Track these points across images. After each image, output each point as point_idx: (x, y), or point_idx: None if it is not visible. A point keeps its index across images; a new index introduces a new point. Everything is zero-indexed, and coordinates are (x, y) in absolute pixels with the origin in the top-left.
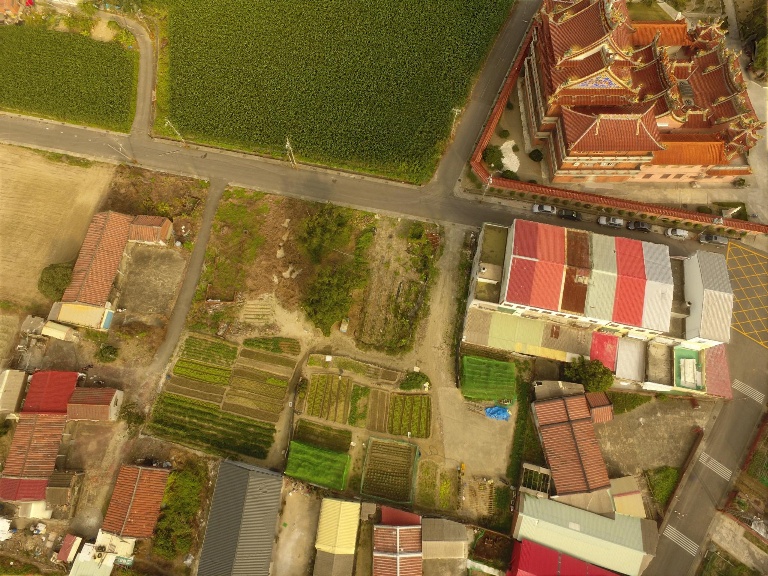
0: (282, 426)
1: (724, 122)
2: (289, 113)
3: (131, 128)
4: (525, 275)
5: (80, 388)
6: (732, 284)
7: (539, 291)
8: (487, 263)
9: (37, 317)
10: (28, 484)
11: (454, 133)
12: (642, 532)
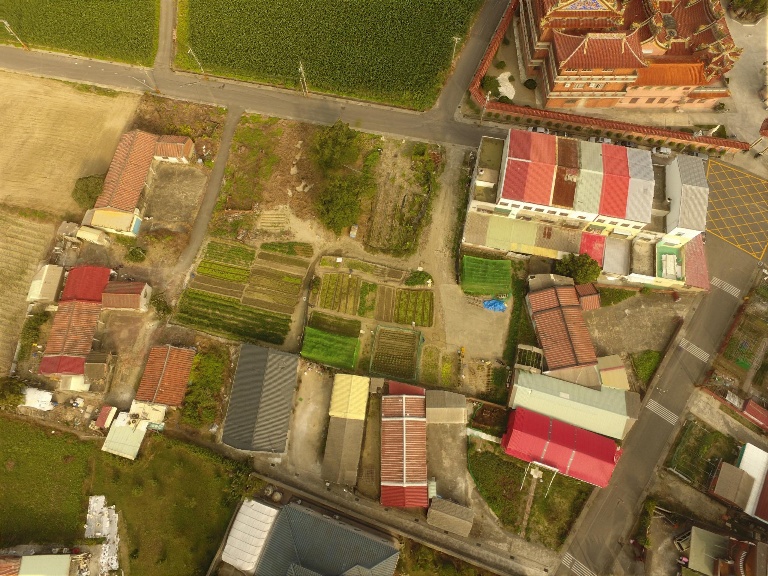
0: (297, 317)
1: (704, 48)
2: (301, 48)
3: (154, 63)
4: (519, 174)
5: (113, 282)
6: (712, 196)
7: (532, 188)
8: (485, 168)
9: (72, 223)
10: (68, 360)
11: (454, 66)
12: (626, 401)
